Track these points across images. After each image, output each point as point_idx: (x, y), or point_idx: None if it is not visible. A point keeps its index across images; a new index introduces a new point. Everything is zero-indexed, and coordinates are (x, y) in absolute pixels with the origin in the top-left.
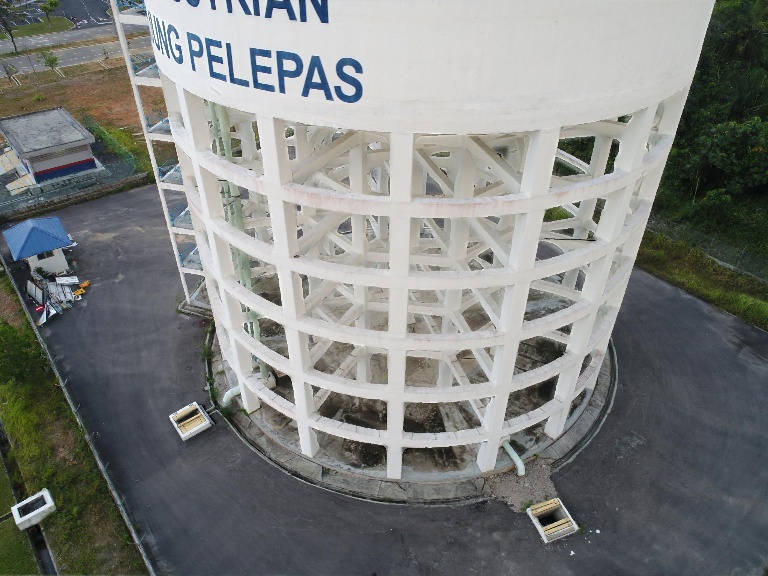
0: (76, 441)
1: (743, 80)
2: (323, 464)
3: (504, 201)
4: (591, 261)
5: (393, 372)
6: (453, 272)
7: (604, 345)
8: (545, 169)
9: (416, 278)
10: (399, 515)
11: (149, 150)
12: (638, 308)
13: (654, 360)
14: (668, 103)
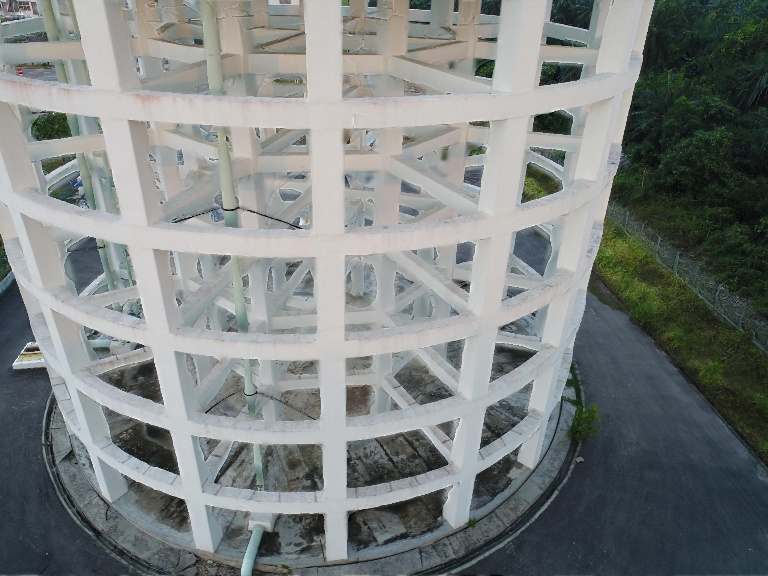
0: None
1: None
2: (73, 447)
3: (59, 87)
4: (272, 255)
5: (53, 337)
6: (62, 202)
7: (460, 458)
8: (98, 41)
9: (19, 196)
10: (73, 543)
11: None
12: (656, 460)
13: (606, 539)
14: (501, 31)
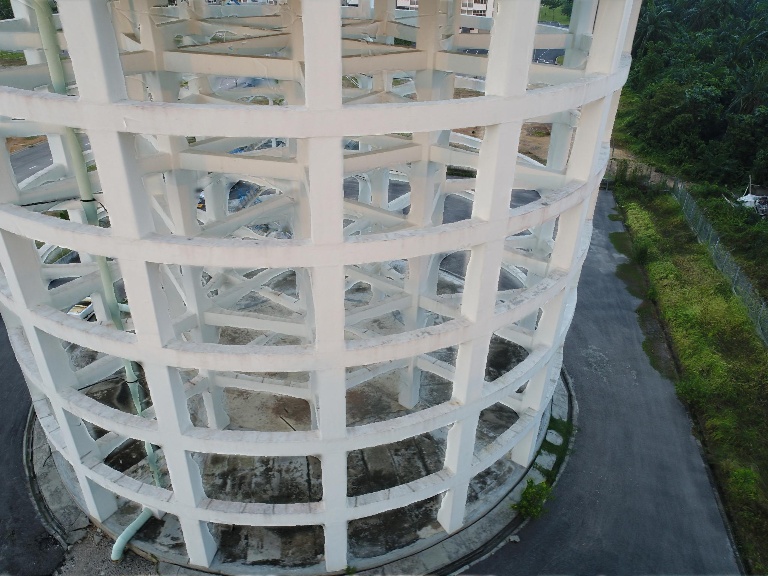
0: None
1: None
2: None
3: None
4: (80, 250)
5: None
6: None
7: None
8: None
9: None
10: (10, 478)
11: None
12: (611, 566)
13: None
14: None
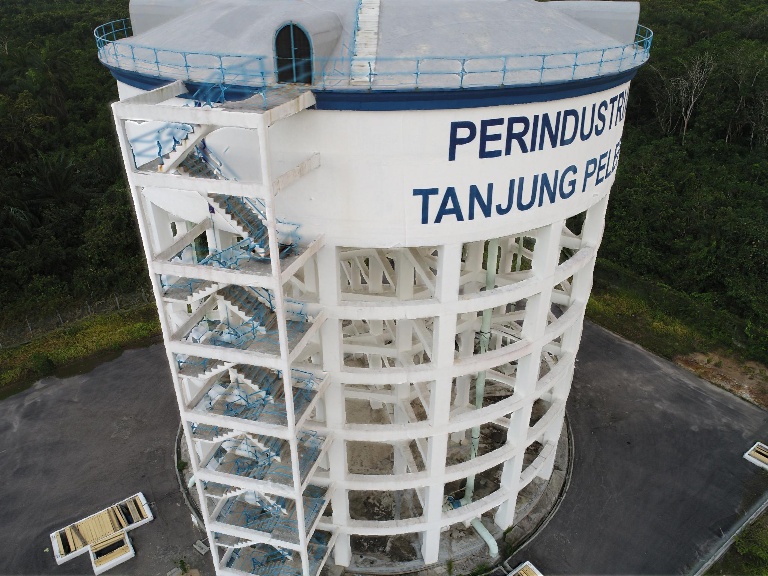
0: None
1: (110, 160)
2: None
3: None
4: None
5: None
6: None
7: None
8: None
9: None
10: (580, 429)
11: (296, 453)
12: None
13: None
14: None
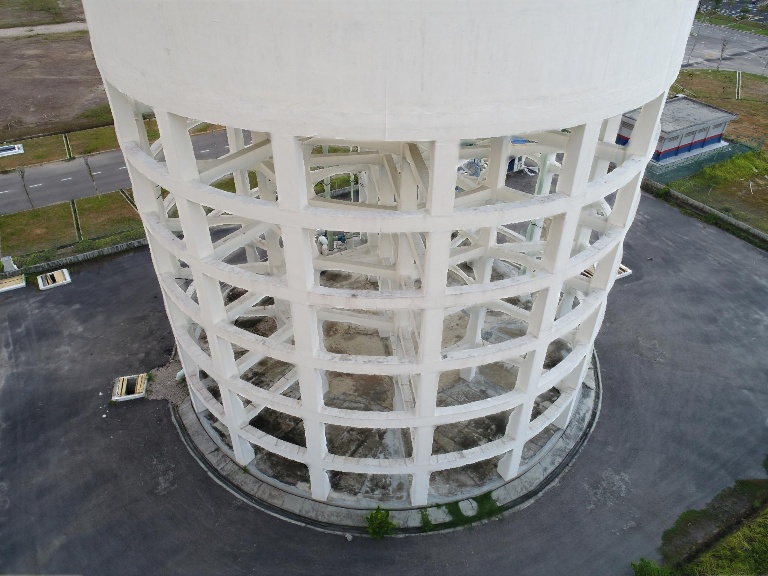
0: None
1: None
2: None
3: None
4: None
5: None
6: (160, 142)
7: None
8: None
9: None
10: None
11: None
12: None
13: (266, 568)
14: None
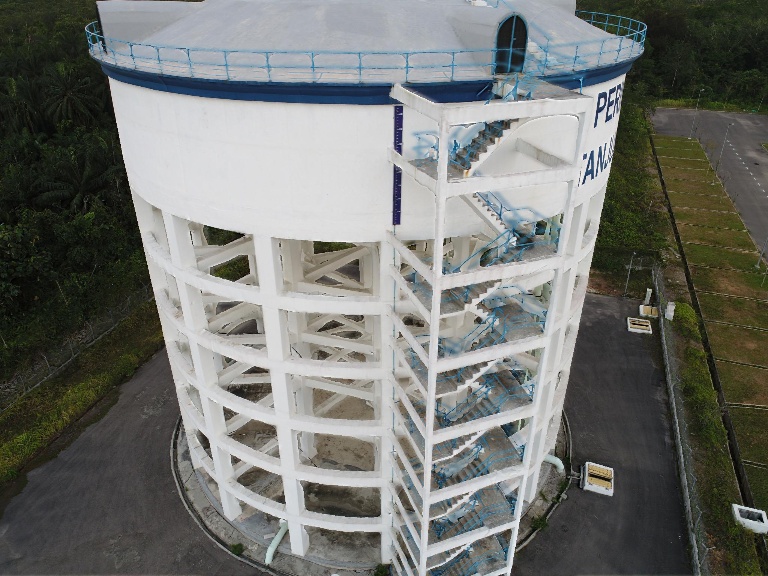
0: (702, 551)
1: None
2: None
3: None
4: None
5: None
6: None
7: None
8: None
9: None
10: None
11: None
12: None
13: None
14: None
